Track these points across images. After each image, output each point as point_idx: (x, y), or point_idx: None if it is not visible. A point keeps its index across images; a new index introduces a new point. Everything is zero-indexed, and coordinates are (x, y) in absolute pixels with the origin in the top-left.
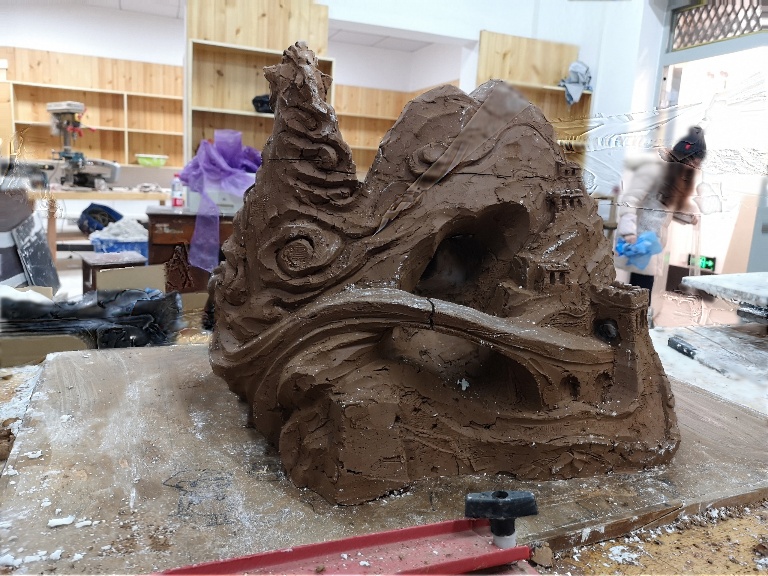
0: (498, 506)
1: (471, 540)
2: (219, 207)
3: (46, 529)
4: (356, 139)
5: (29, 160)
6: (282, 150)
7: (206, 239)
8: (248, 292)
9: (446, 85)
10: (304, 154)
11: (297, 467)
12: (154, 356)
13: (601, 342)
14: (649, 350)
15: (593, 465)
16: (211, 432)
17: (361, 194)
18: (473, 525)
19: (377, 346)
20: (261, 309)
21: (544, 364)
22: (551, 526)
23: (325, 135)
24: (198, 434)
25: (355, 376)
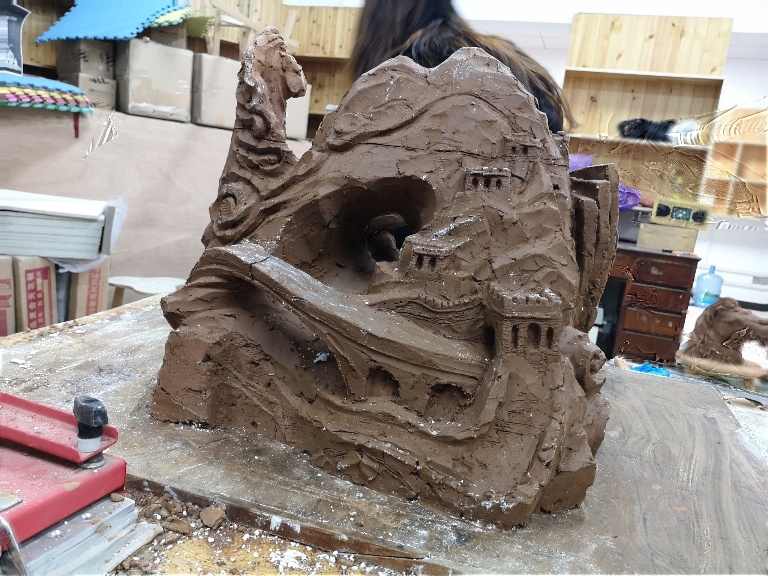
0: None
1: (75, 435)
2: None
3: (8, 362)
4: None
5: None
6: (236, 121)
7: None
8: None
9: None
10: (245, 124)
11: None
12: None
13: (476, 352)
14: (548, 381)
15: (390, 481)
16: None
17: (287, 162)
18: None
19: (236, 295)
20: None
21: (345, 344)
22: (253, 499)
23: (253, 106)
24: None
25: (203, 314)
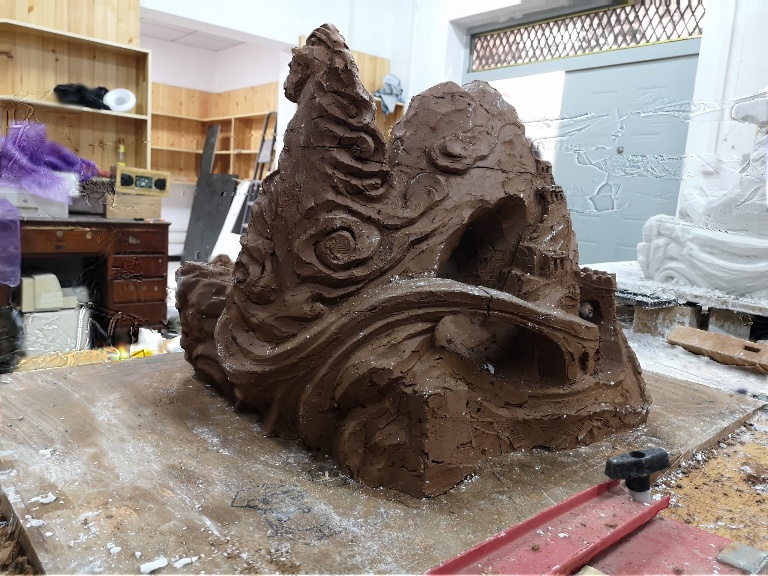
0: (642, 464)
1: (615, 500)
2: (19, 210)
3: None
4: (191, 138)
5: (47, 134)
6: (318, 137)
7: (3, 247)
8: (278, 289)
9: (449, 82)
10: (342, 142)
11: (367, 467)
12: (94, 374)
13: (588, 321)
14: None
15: (603, 430)
16: (234, 447)
17: (390, 185)
18: (607, 487)
19: None
20: (301, 306)
21: (571, 342)
22: None
23: (366, 123)
24: (222, 450)
25: (421, 367)
